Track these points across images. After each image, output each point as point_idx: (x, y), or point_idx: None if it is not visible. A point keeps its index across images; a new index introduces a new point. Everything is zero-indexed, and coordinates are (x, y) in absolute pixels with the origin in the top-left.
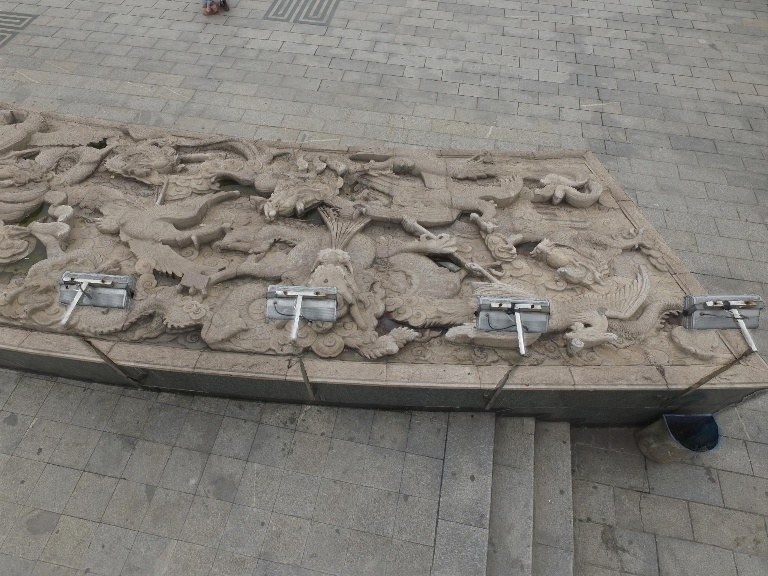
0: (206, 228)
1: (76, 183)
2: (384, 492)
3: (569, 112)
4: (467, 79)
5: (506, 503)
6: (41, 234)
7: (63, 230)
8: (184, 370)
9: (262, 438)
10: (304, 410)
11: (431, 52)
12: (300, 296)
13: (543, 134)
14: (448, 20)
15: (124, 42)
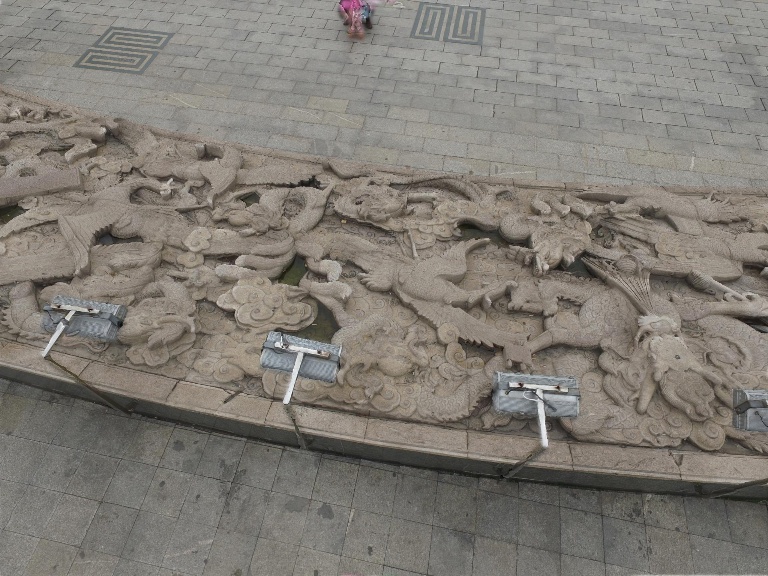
0: (494, 287)
1: (310, 229)
2: None
3: (767, 141)
4: (647, 104)
5: None
6: (322, 296)
7: (346, 291)
8: (562, 468)
9: (612, 534)
10: (646, 499)
11: (599, 74)
12: None
13: (749, 166)
14: (605, 38)
15: (273, 63)
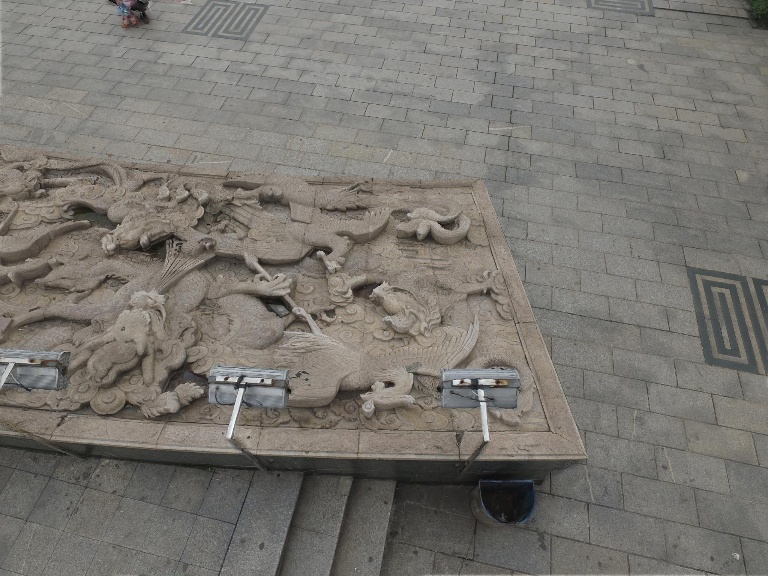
0: (29, 264)
1: None
2: (163, 560)
3: (476, 136)
4: (377, 99)
5: (300, 573)
6: None
7: None
8: None
9: (49, 495)
10: (101, 464)
11: (346, 70)
12: (12, 364)
13: (443, 159)
14: (371, 36)
15: (34, 55)
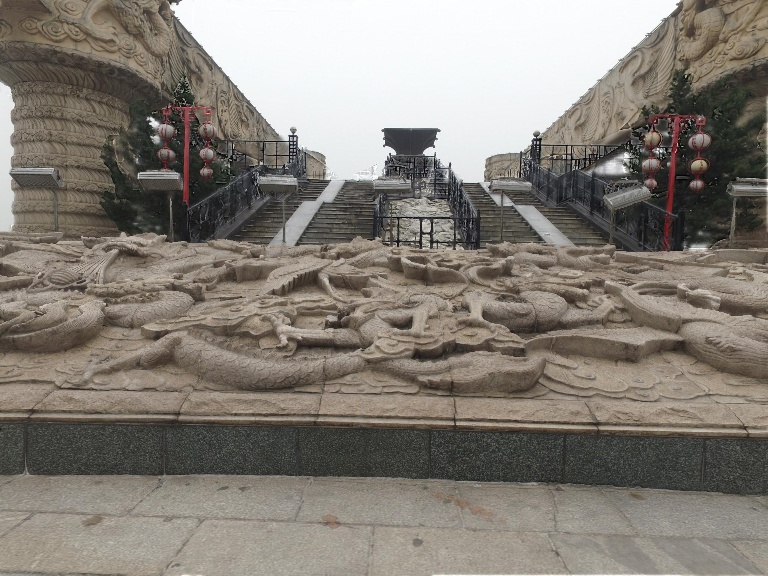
0: (251, 260)
1: None
2: None
3: None
4: None
5: None
6: None
7: (391, 254)
8: None
9: None
10: None
11: None
12: None
13: None
14: None
15: None
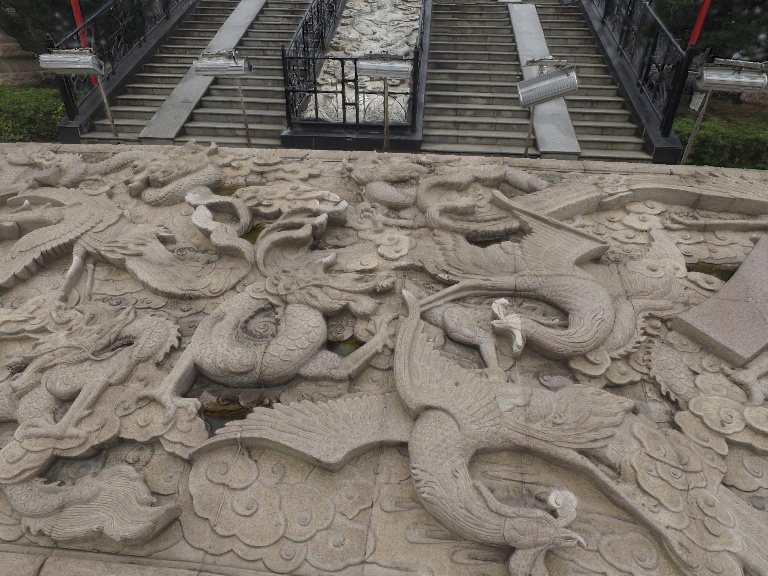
0: (5, 215)
1: None
2: None
3: None
4: None
5: None
6: None
7: (192, 196)
8: None
9: None
10: None
11: None
12: None
13: None
14: None
15: None
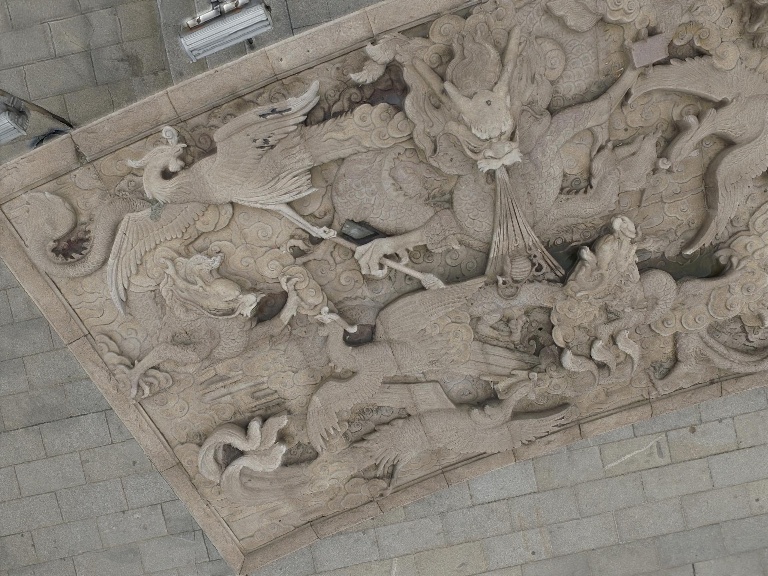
0: (688, 145)
1: None
2: None
3: None
4: None
5: None
6: None
7: None
8: None
9: None
10: None
11: None
12: None
13: None
14: None
15: None
